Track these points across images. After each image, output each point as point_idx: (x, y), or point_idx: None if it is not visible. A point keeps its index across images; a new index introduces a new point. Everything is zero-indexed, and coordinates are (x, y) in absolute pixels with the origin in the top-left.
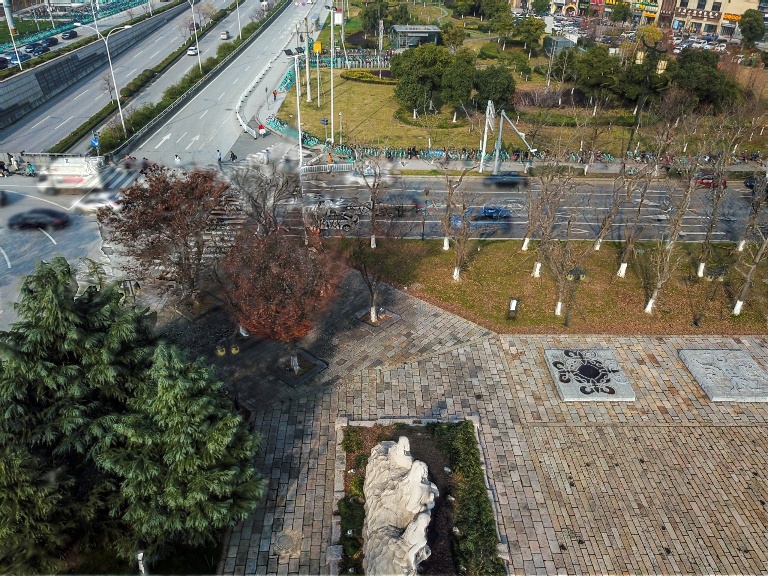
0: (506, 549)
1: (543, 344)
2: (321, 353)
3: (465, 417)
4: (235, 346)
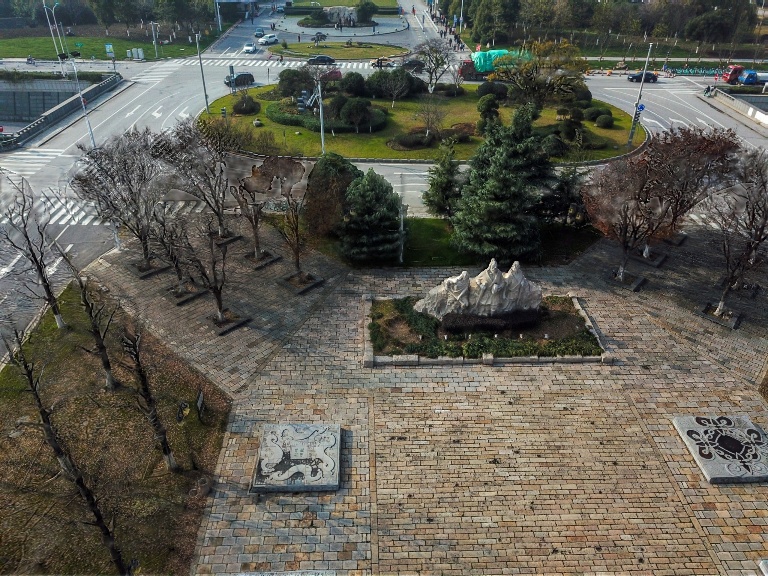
0: (489, 358)
1: (766, 423)
2: (648, 289)
3: (614, 357)
4: (579, 214)
